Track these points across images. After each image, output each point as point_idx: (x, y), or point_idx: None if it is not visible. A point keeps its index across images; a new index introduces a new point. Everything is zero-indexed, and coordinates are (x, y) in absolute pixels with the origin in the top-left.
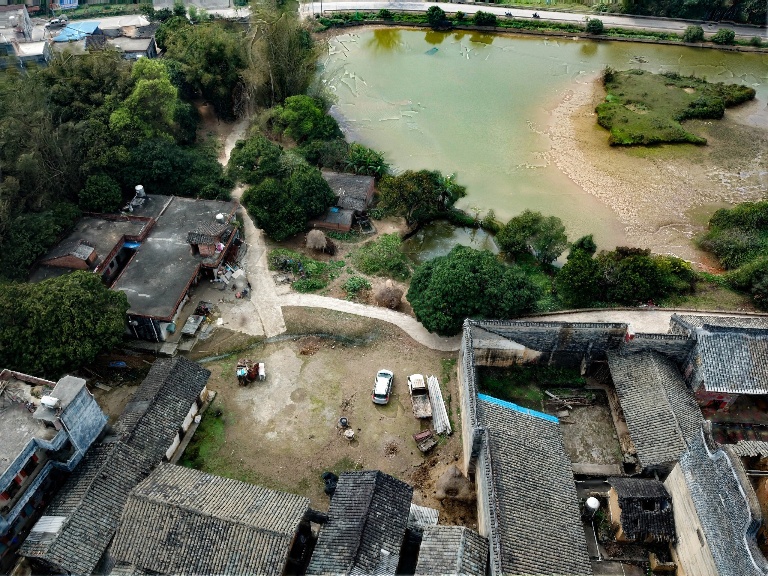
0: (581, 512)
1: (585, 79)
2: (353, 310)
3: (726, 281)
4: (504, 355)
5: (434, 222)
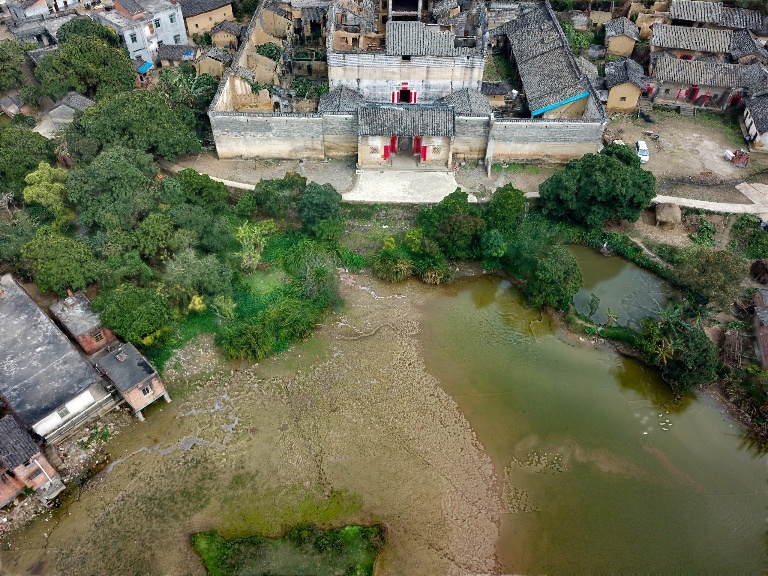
0: None
1: None
2: (692, 201)
3: (345, 251)
4: None
5: None
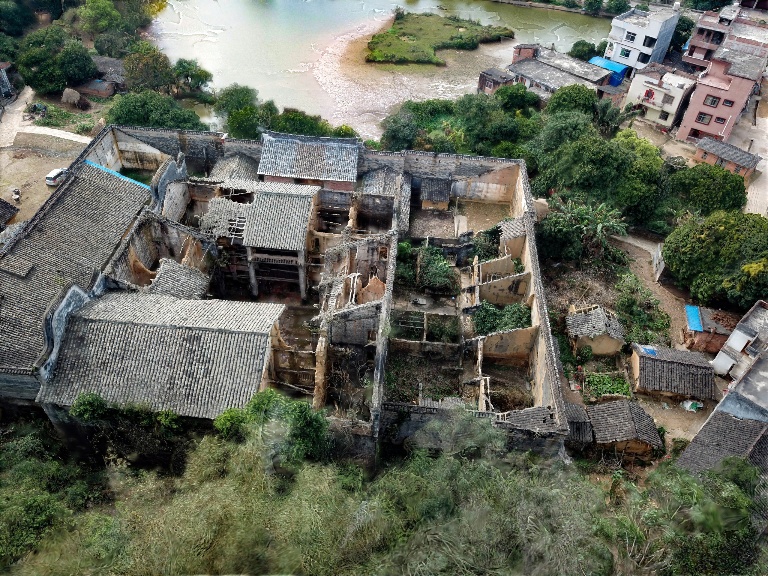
0: None
1: (383, 18)
2: (70, 137)
3: (380, 144)
4: (148, 158)
5: (185, 100)
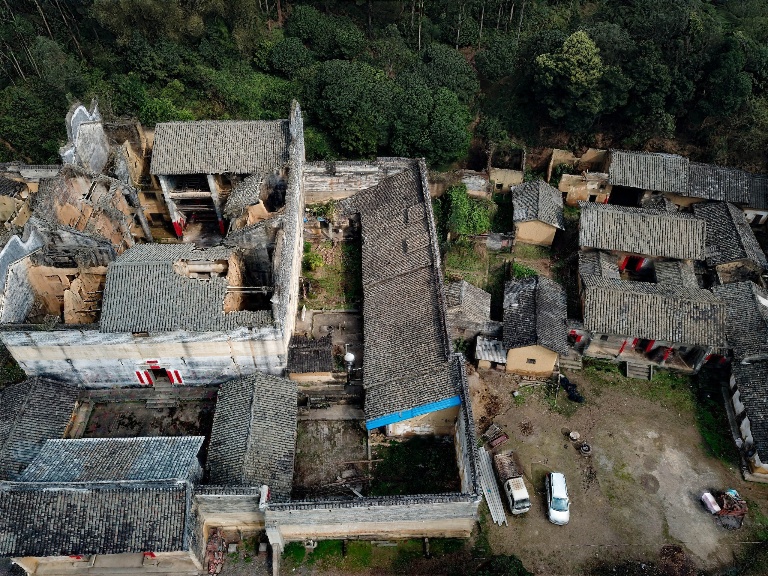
0: (354, 373)
1: None
2: None
3: None
4: None
5: None
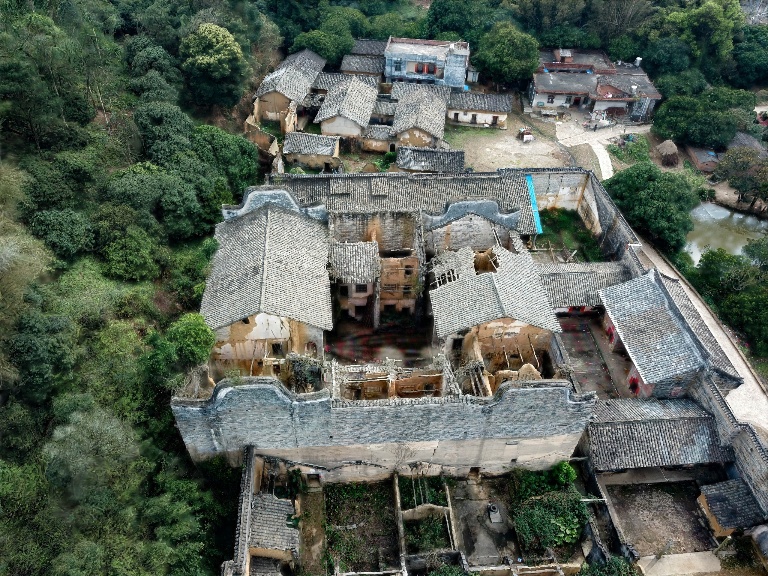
0: None
1: None
2: (605, 170)
3: None
4: None
5: (763, 223)
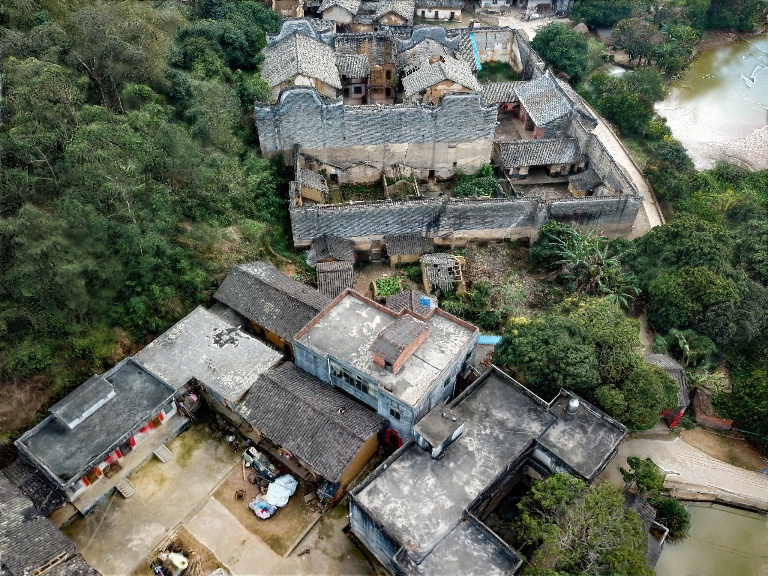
0: None
1: None
2: None
3: None
4: None
5: None
